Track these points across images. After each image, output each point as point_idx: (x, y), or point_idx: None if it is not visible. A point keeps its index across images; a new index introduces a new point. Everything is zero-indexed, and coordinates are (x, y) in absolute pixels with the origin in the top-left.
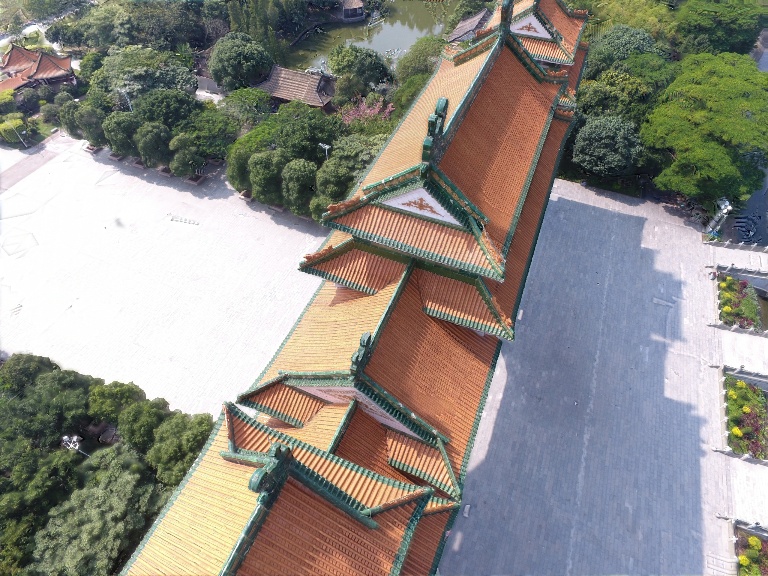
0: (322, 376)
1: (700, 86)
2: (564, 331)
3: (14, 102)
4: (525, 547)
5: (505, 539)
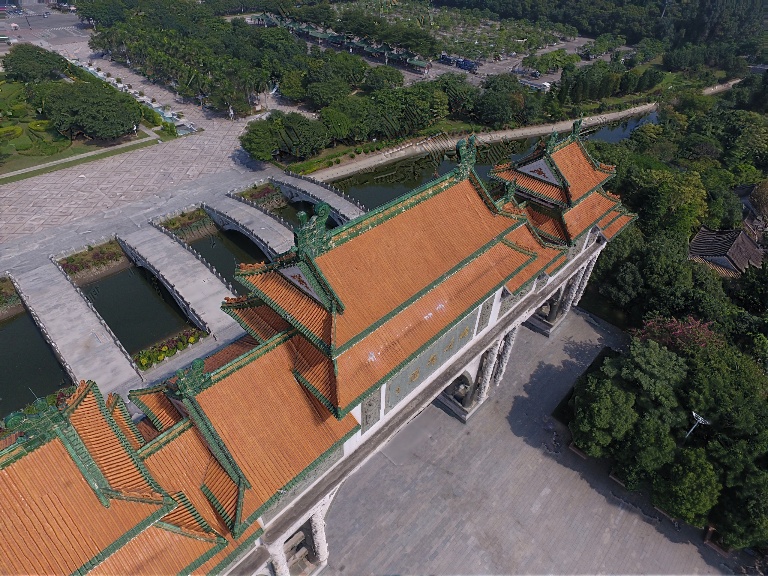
0: None
1: None
2: None
3: None
4: None
5: None
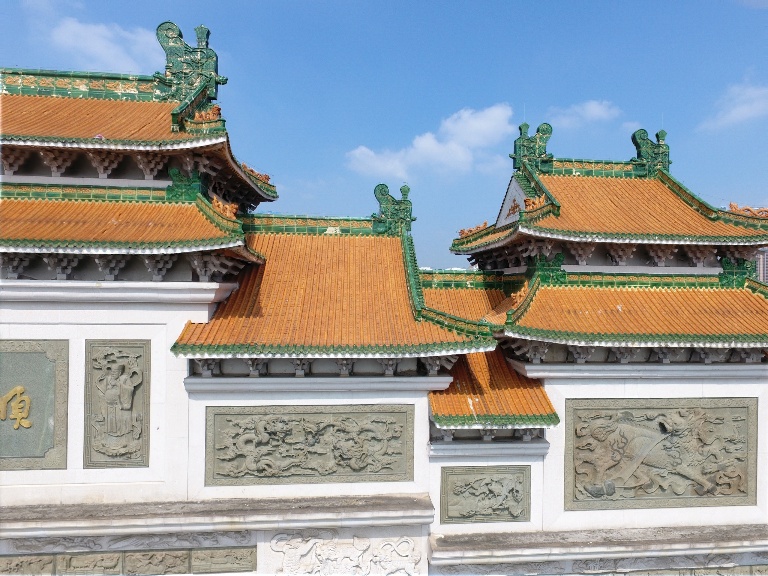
0: None
1: None
2: None
3: None
4: None
5: None
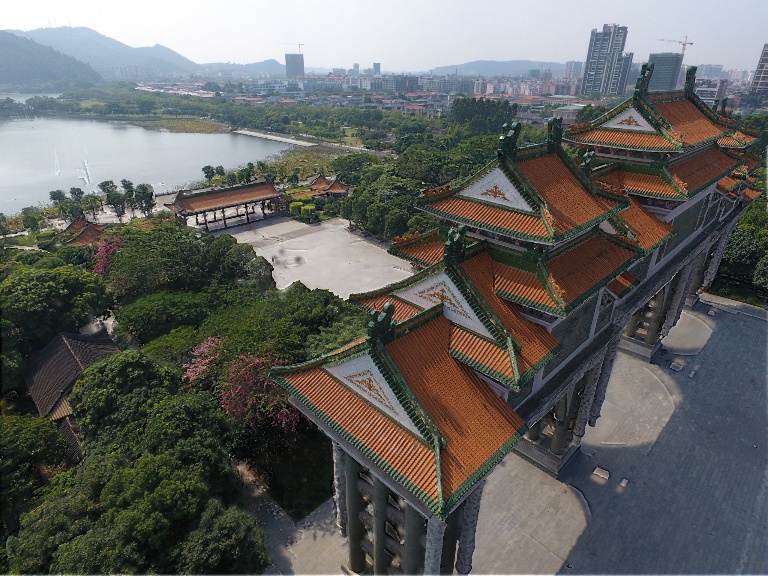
0: None
1: None
2: (742, 395)
3: (311, 201)
4: (689, 528)
5: (666, 515)
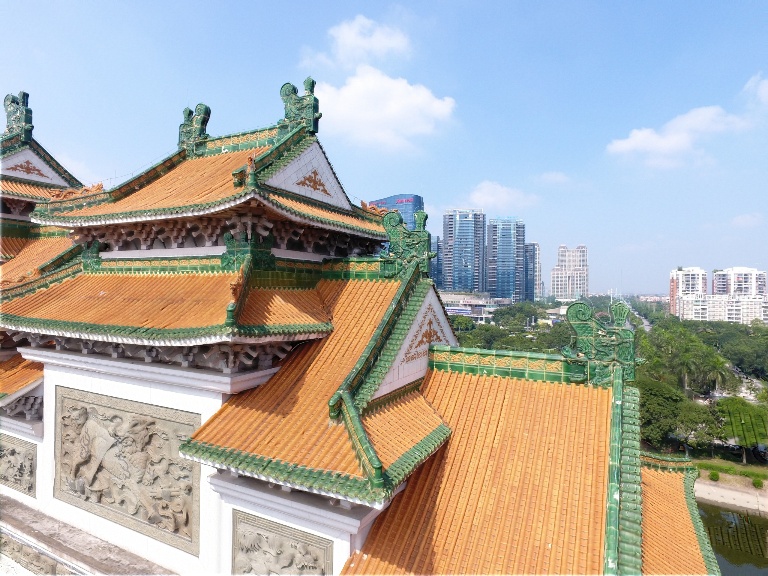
0: (68, 255)
1: None
2: None
3: None
4: None
5: None
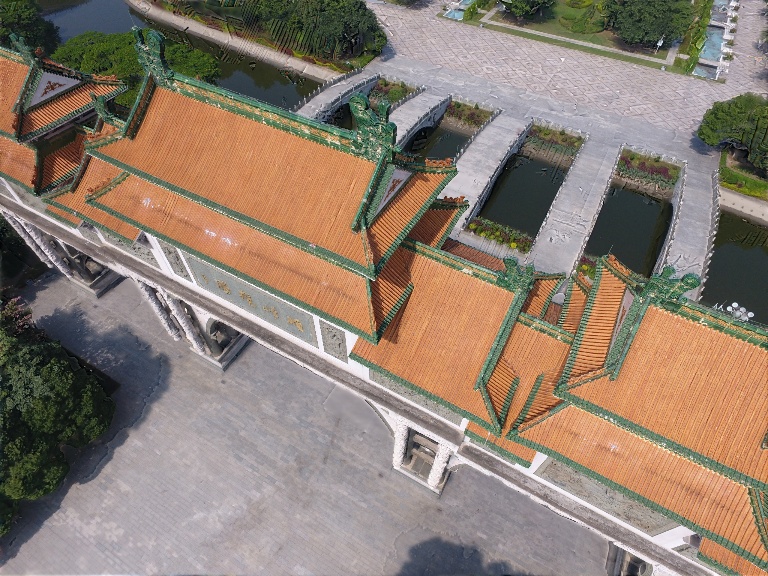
0: None
1: (114, 68)
2: None
3: None
4: None
5: None
